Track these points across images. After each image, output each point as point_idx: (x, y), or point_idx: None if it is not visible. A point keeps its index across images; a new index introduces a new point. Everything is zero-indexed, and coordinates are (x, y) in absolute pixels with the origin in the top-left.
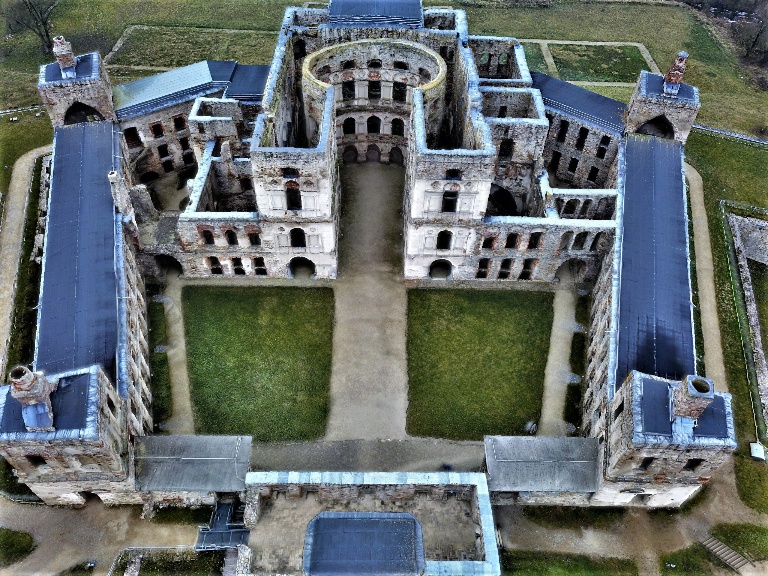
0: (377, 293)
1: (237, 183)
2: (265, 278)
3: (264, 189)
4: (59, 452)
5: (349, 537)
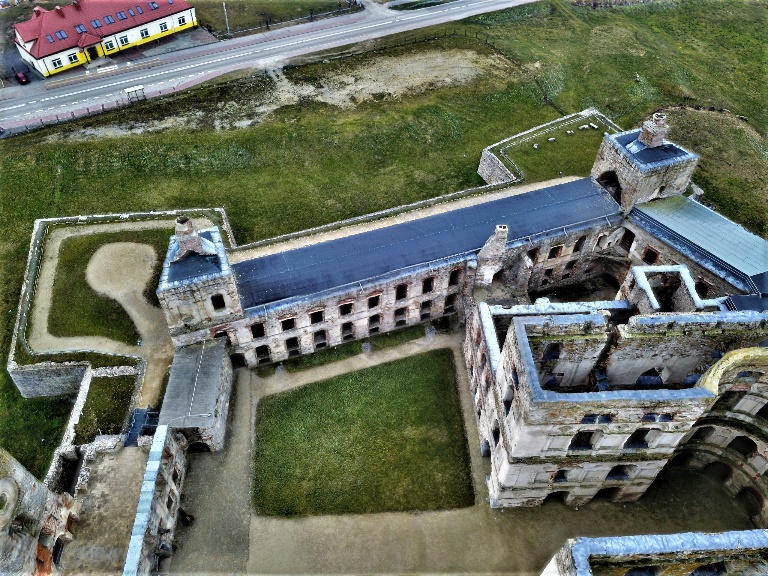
0: (475, 567)
1: None
2: (477, 424)
3: None
4: None
5: None
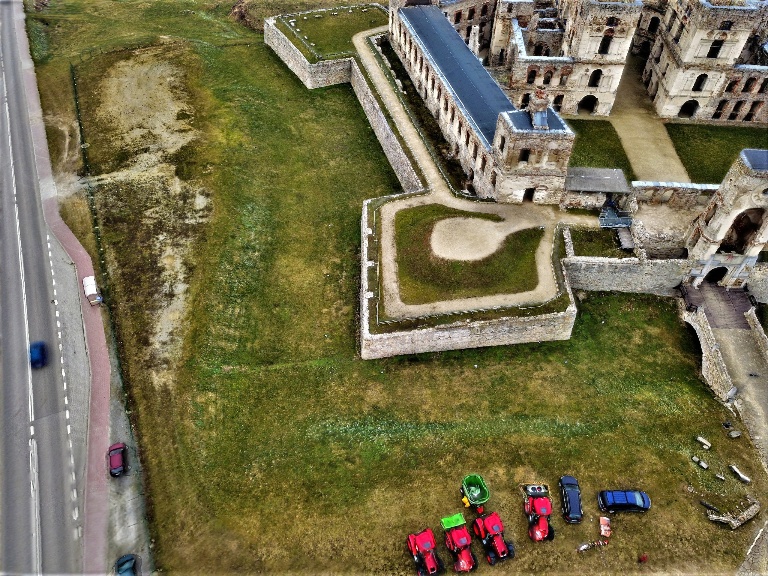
0: (642, 124)
1: (532, 49)
2: None
3: (588, 35)
4: (544, 146)
5: (767, 156)
